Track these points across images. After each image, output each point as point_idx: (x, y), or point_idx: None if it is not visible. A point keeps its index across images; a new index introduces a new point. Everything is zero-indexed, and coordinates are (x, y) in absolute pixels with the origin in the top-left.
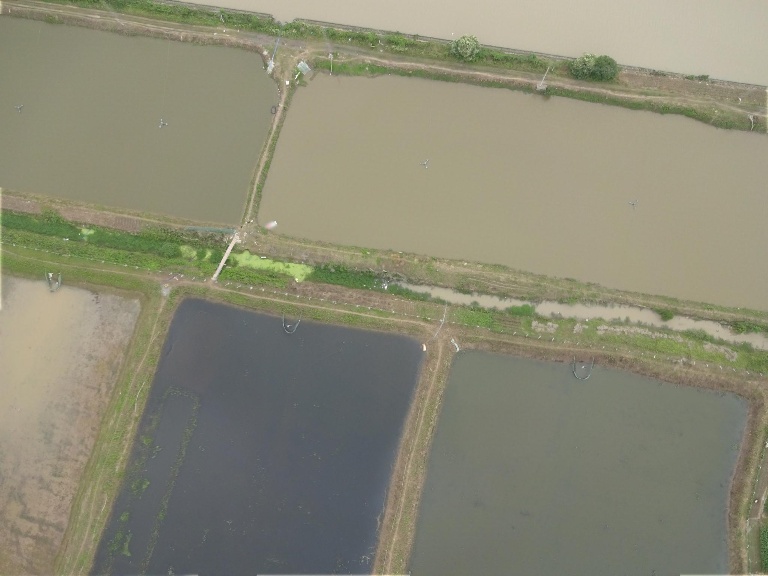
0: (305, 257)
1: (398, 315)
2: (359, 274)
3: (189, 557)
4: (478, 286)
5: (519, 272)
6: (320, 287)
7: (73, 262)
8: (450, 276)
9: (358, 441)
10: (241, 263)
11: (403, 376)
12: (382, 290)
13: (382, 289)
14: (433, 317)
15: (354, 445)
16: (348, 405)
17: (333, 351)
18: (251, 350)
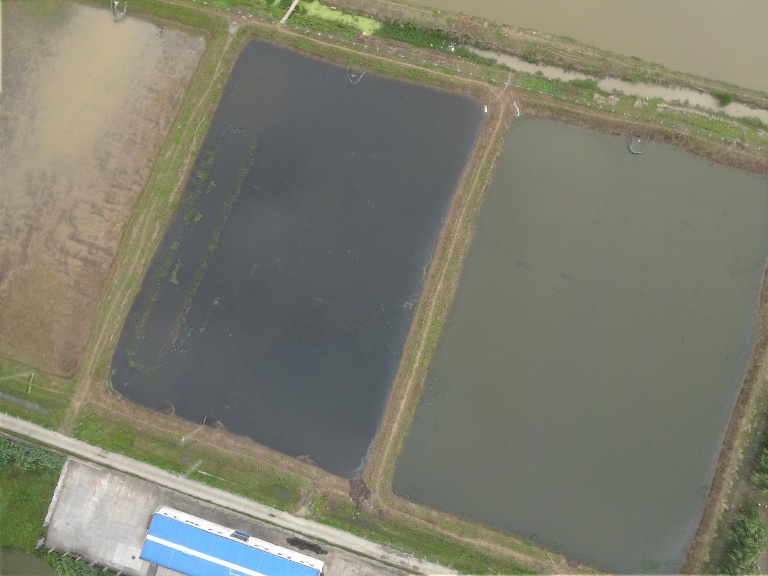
0: (375, 11)
1: (464, 74)
2: (428, 32)
3: (236, 289)
4: (545, 55)
5: (586, 46)
6: (388, 42)
7: None
8: (518, 42)
9: (412, 193)
10: (310, 12)
11: (462, 135)
12: (449, 51)
13: (449, 50)
14: (498, 80)
15: (408, 197)
16: (405, 158)
17: (395, 105)
18: (314, 96)
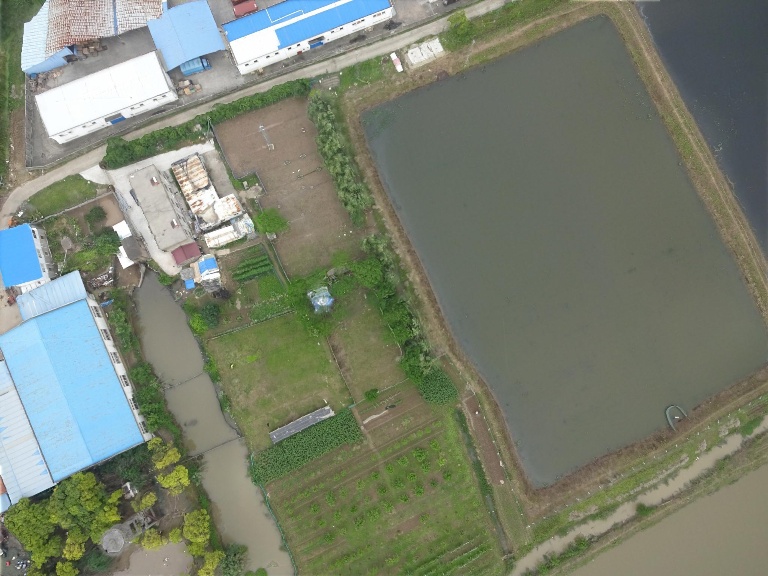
0: None
1: None
2: None
3: None
4: None
5: None
6: None
7: None
8: None
9: None
10: None
11: None
12: None
13: None
14: None
15: None
16: None
17: None
18: None
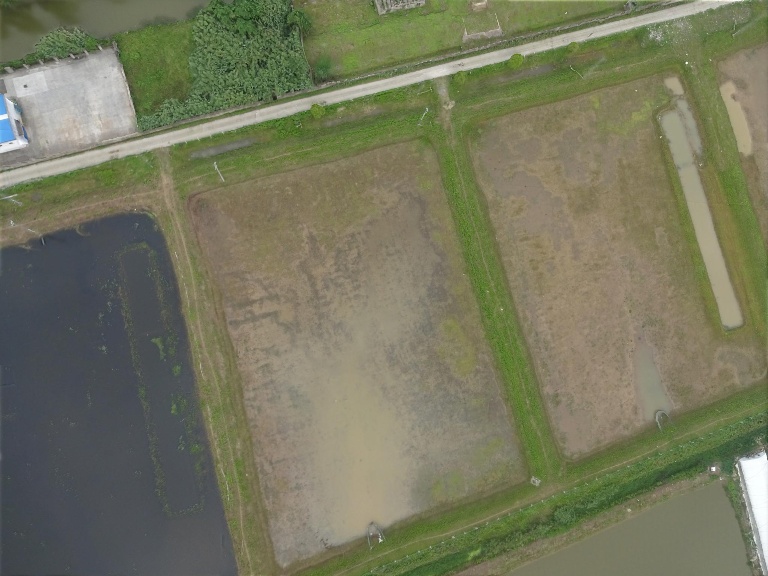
0: None
1: None
2: None
3: (94, 371)
4: None
5: None
6: None
7: (364, 568)
8: None
9: None
10: None
11: None
12: None
13: None
14: None
15: None
16: None
17: None
18: None
